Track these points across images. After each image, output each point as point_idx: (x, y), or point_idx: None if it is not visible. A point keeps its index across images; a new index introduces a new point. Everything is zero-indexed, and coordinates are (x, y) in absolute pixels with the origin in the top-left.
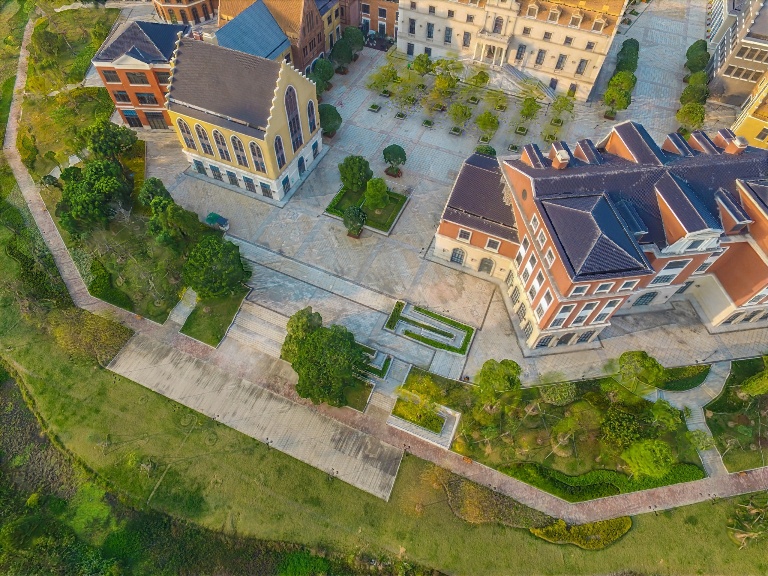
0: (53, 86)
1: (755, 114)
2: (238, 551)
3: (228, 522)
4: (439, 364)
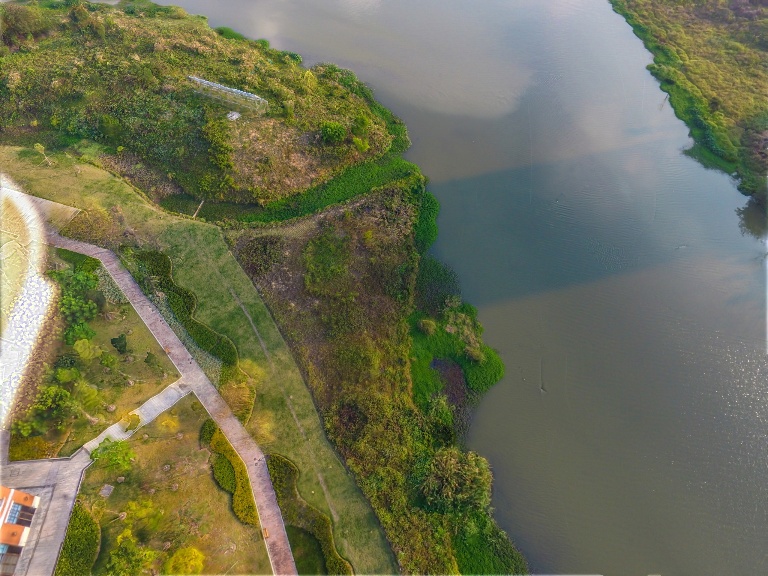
0: (145, 555)
1: None
2: (4, 140)
3: (6, 148)
4: None
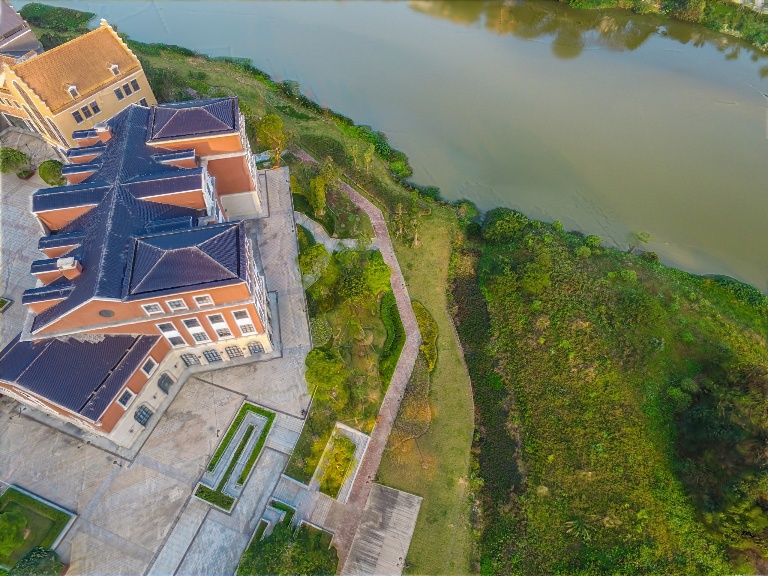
0: None
1: (54, 112)
2: None
3: None
4: (283, 443)
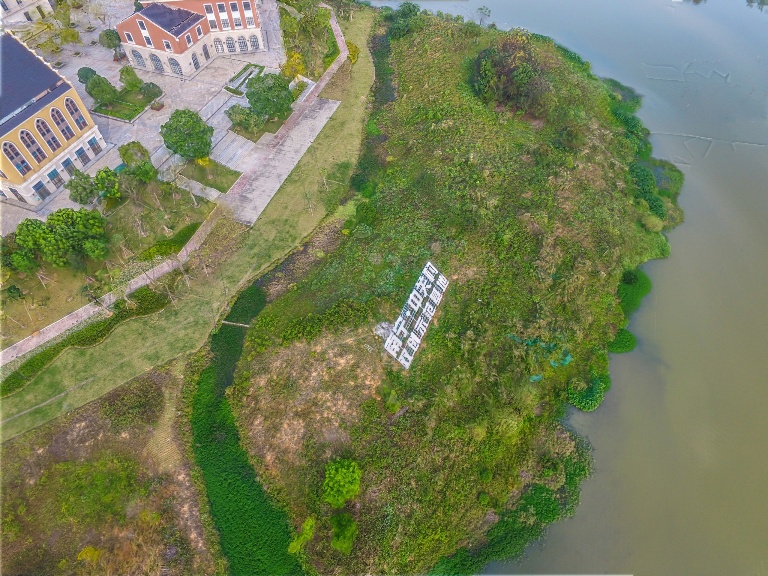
0: None
1: None
2: (367, 148)
3: (354, 152)
4: None
